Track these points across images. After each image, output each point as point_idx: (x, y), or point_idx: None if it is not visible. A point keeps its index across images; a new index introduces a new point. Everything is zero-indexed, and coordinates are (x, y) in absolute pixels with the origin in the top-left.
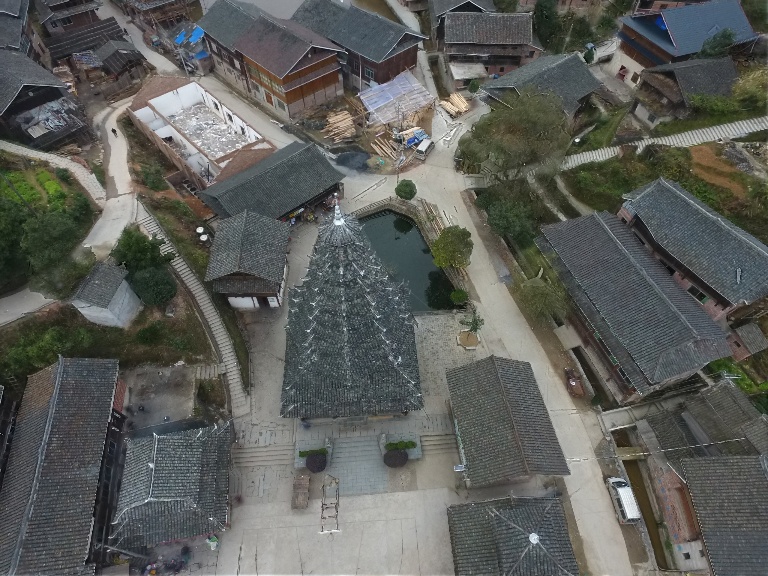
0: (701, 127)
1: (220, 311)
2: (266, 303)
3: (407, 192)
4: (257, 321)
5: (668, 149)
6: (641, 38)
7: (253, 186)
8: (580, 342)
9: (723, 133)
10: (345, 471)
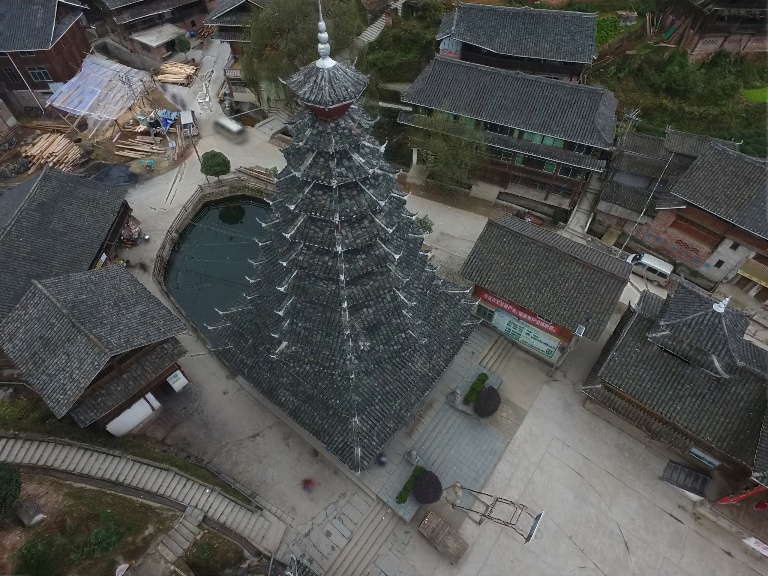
0: None
1: (114, 450)
2: (167, 392)
3: (220, 163)
4: (175, 424)
5: None
6: None
7: (1, 262)
8: (497, 188)
9: None
10: (454, 468)
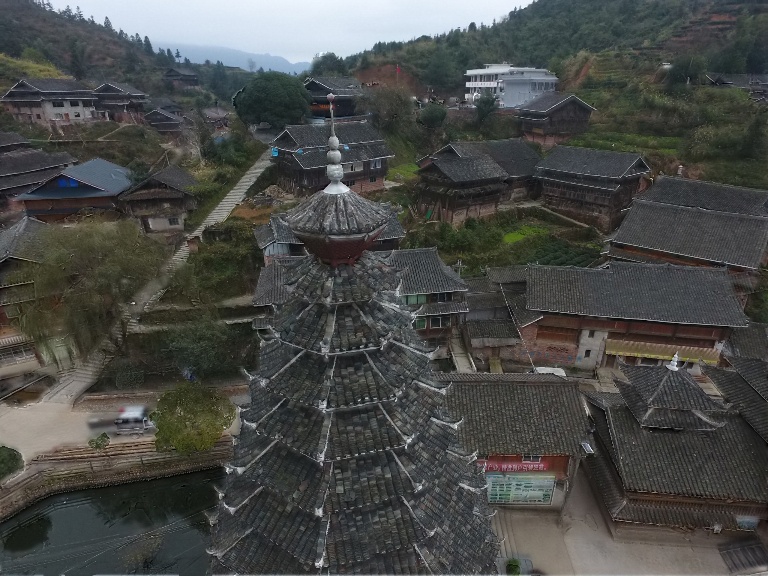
0: (213, 208)
1: None
2: None
3: (7, 462)
4: None
5: (221, 224)
6: (60, 202)
7: None
8: None
9: (232, 202)
10: None
